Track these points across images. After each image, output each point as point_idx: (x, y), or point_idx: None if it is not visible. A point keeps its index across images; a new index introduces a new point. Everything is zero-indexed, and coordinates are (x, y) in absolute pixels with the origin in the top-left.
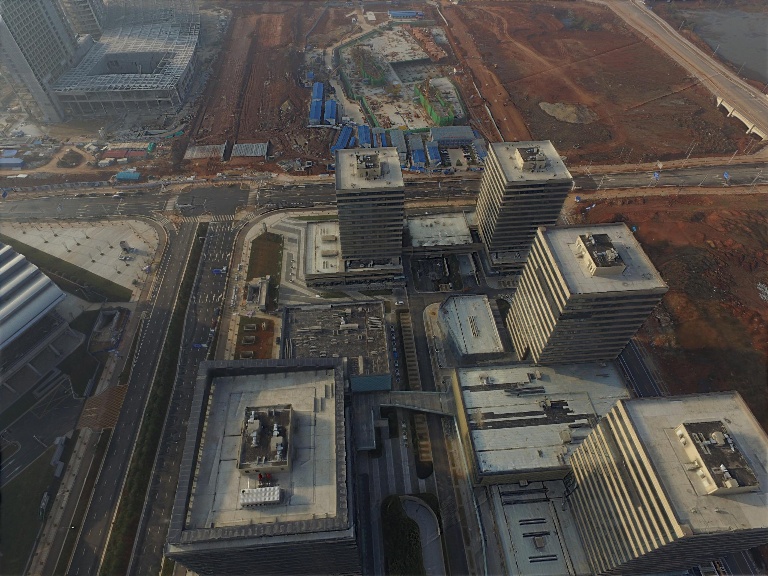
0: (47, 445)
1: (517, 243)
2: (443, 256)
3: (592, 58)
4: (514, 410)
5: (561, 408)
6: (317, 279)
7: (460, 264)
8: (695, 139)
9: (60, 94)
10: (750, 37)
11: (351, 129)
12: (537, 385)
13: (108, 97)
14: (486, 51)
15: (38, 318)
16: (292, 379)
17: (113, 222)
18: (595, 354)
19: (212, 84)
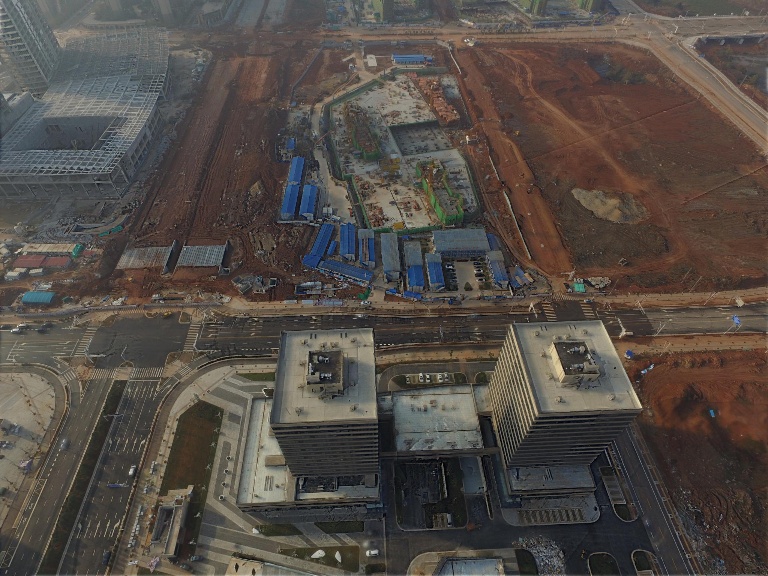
0: None
1: (548, 461)
2: (440, 459)
3: (636, 123)
4: None
5: None
6: (255, 506)
7: (464, 477)
8: None
9: None
10: None
11: (332, 228)
12: None
13: (35, 179)
14: (506, 111)
15: None
16: None
17: (1, 376)
18: None
19: (172, 154)
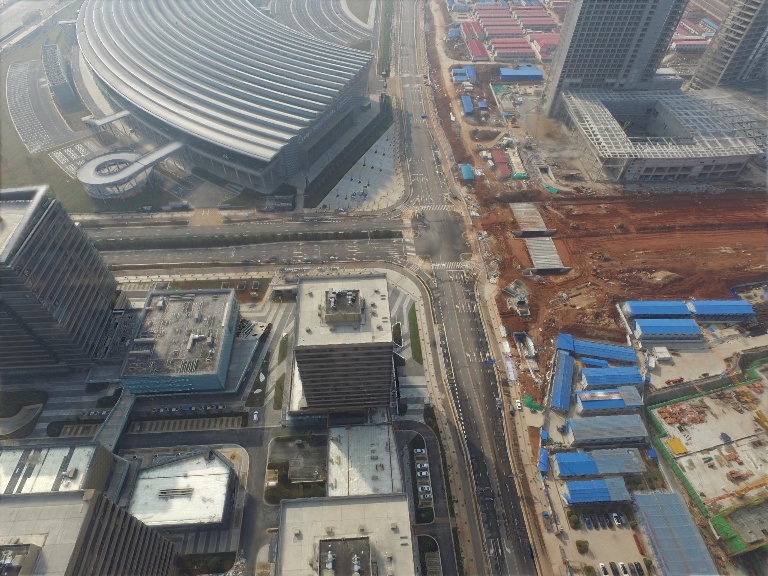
0: None
1: None
2: None
3: None
4: None
5: None
6: None
7: None
8: None
9: None
10: None
11: (630, 359)
12: None
13: None
14: None
15: (250, 155)
16: None
17: (401, 179)
18: None
19: (684, 198)
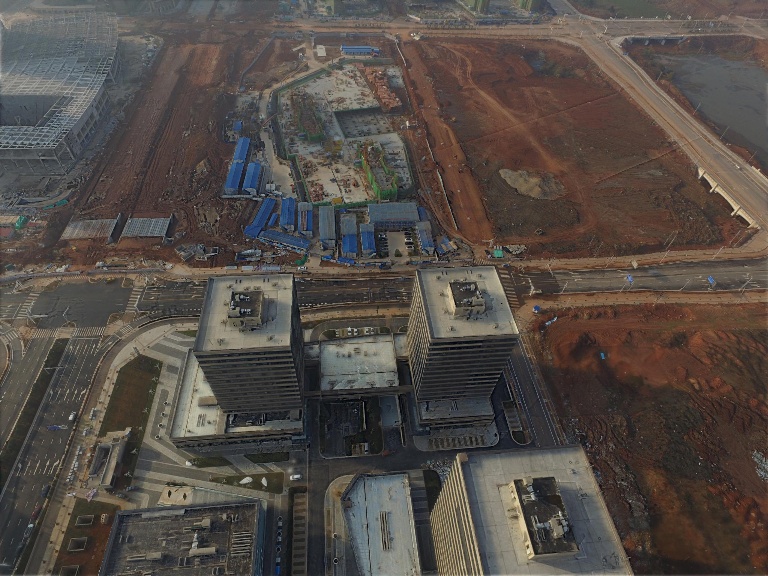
0: None
1: (453, 392)
2: (362, 398)
3: (562, 112)
4: None
5: None
6: (188, 441)
7: (382, 412)
8: (675, 225)
9: None
10: (732, 90)
11: (274, 202)
12: None
13: None
14: (445, 100)
15: None
16: None
17: None
18: None
19: (120, 133)
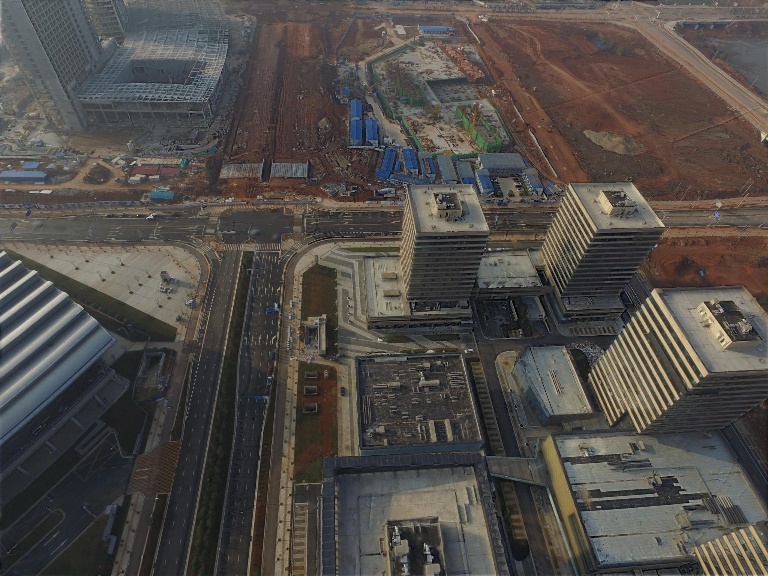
0: (96, 515)
1: (592, 289)
2: (509, 298)
3: (630, 85)
4: (622, 487)
5: (672, 486)
6: (380, 322)
7: (528, 308)
8: (747, 176)
9: (84, 102)
10: None
11: (395, 152)
12: (642, 457)
13: (136, 107)
14: (523, 73)
15: (86, 368)
16: (426, 478)
17: (149, 248)
18: (703, 425)
19: (242, 96)
